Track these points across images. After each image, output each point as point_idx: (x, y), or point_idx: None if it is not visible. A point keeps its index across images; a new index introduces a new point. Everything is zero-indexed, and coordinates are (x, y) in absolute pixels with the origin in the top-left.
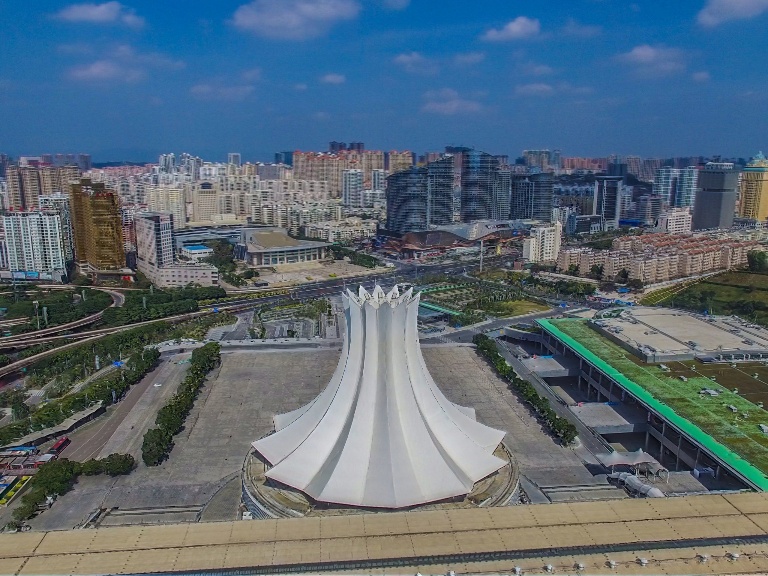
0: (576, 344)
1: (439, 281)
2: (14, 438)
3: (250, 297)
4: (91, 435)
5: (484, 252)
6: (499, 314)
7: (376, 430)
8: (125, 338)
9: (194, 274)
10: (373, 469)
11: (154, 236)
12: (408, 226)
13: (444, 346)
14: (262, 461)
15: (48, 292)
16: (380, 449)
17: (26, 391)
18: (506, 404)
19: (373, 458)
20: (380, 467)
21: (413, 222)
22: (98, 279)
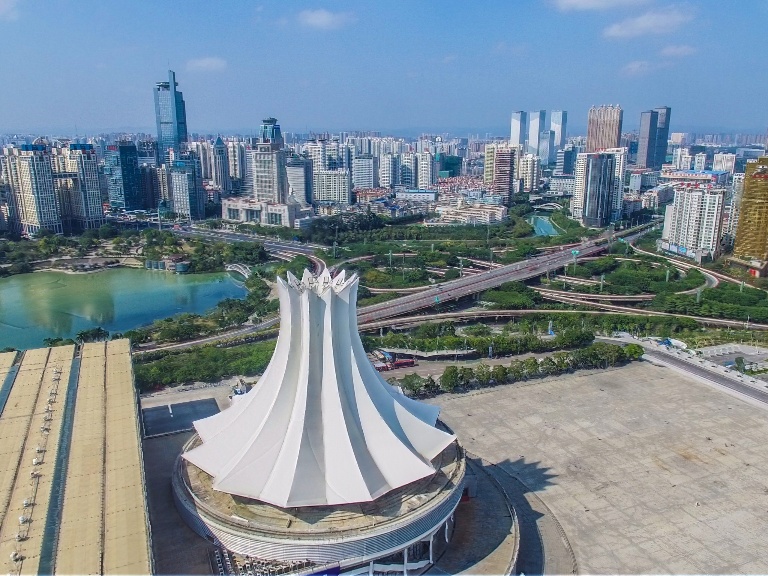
0: None
1: None
2: (391, 346)
3: None
4: (432, 368)
5: None
6: None
7: None
8: (621, 320)
9: None
10: None
11: None
12: None
13: None
14: None
15: (667, 268)
16: None
17: (492, 330)
18: None
19: None
20: None
21: None
22: (730, 267)
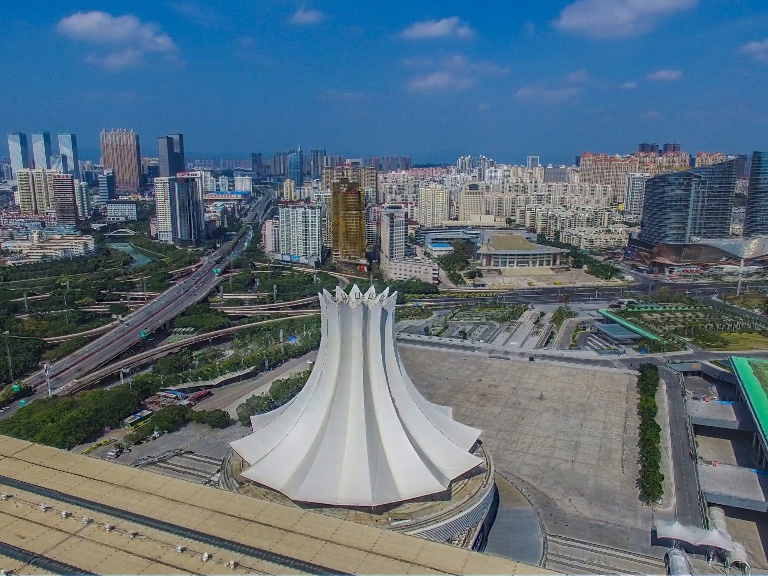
0: (759, 392)
1: (673, 301)
2: (174, 383)
3: (459, 296)
4: (230, 393)
5: (761, 273)
6: (707, 345)
7: (323, 425)
8: None
9: (418, 269)
10: (306, 461)
11: (389, 231)
12: (661, 237)
13: (609, 370)
14: None
15: (298, 274)
16: (318, 443)
17: (224, 350)
18: (620, 444)
19: (311, 450)
20: (309, 460)
21: (667, 233)
22: (341, 267)
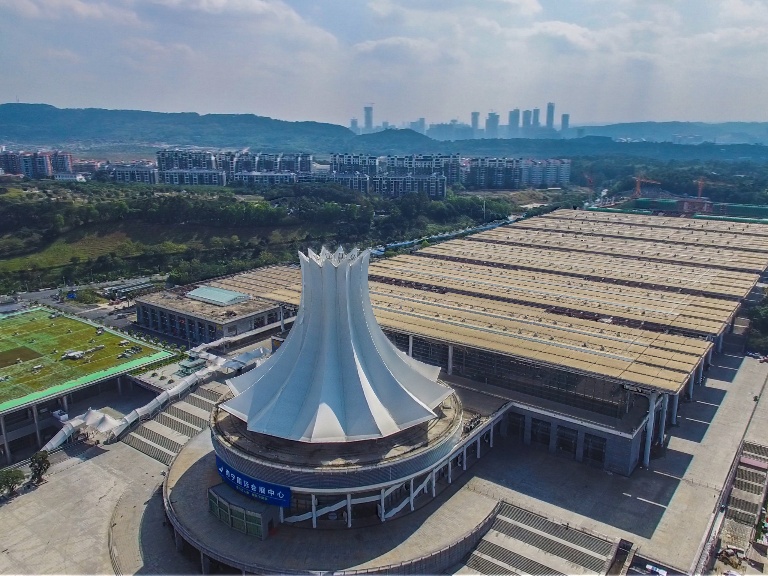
0: None
1: None
2: None
3: None
4: None
5: None
6: None
7: None
8: None
9: None
10: None
11: None
12: None
13: None
14: (427, 435)
15: None
16: None
17: None
18: None
19: None
20: None
21: None
22: None
